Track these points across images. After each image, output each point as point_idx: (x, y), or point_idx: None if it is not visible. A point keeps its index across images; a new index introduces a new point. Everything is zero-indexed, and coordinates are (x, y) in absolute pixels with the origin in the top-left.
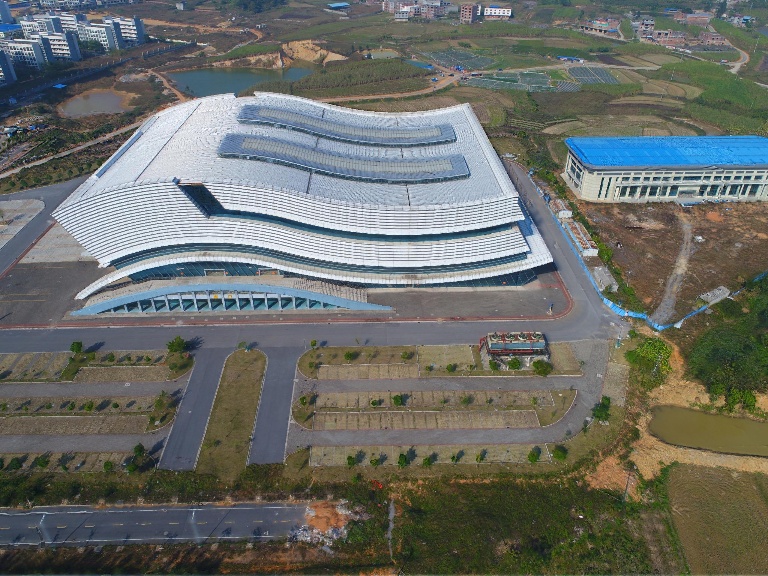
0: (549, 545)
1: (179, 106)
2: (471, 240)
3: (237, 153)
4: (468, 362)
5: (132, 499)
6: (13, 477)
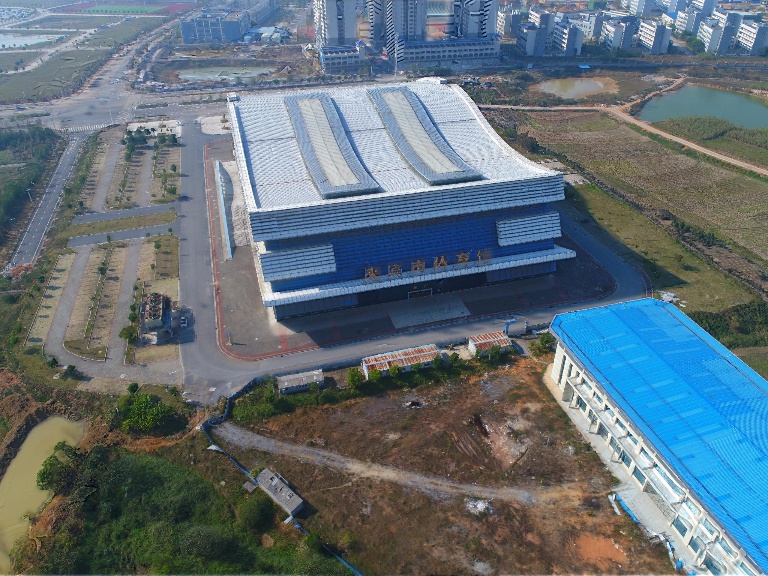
0: None
1: (422, 79)
2: None
3: None
4: None
5: None
6: None
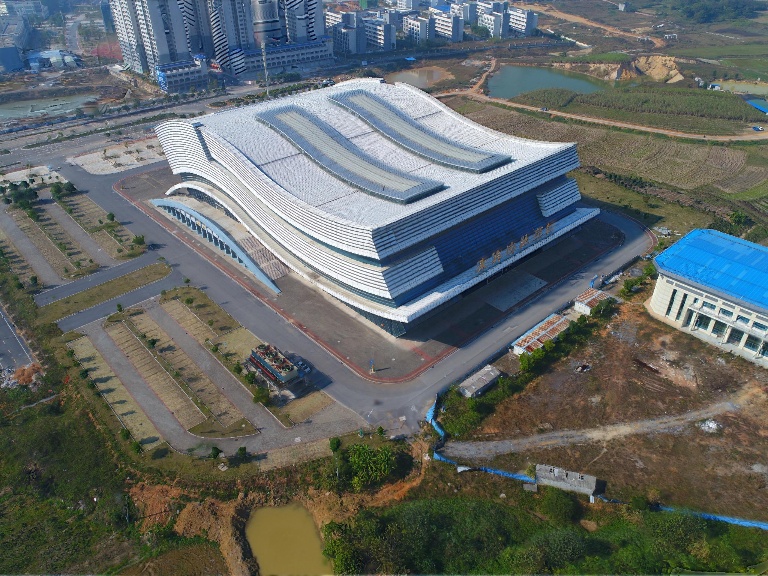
0: (53, 493)
1: (347, 81)
2: (348, 261)
3: (264, 119)
4: (244, 358)
5: (6, 303)
6: (1, 262)
